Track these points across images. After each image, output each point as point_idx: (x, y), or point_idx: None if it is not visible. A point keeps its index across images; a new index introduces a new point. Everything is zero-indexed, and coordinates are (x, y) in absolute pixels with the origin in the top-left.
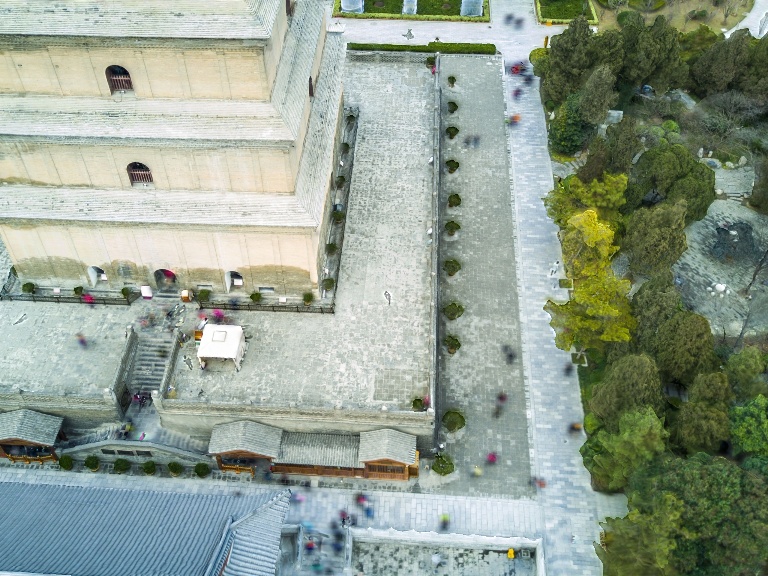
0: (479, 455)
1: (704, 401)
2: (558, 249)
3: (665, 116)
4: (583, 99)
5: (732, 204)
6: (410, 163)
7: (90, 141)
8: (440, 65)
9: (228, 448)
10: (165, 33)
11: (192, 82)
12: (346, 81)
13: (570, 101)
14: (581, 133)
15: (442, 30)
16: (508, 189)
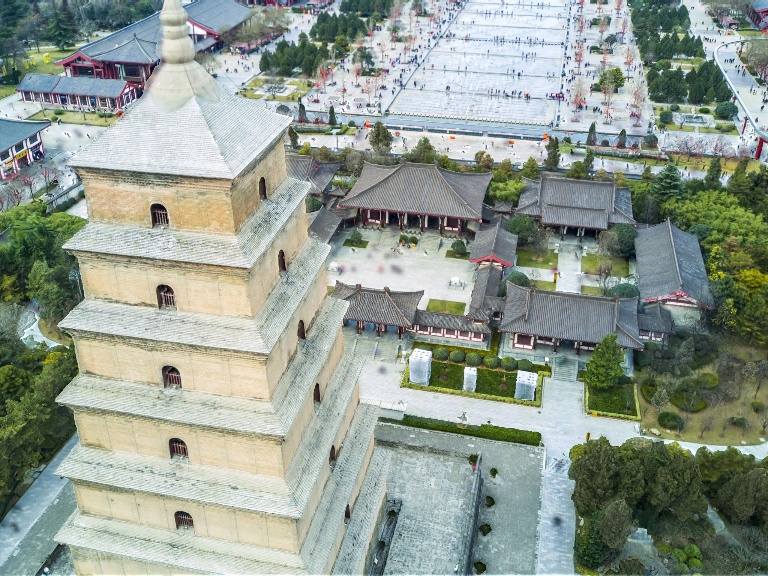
0: None
1: None
2: None
3: (689, 538)
4: (603, 523)
5: None
6: (437, 568)
7: (154, 562)
8: (487, 452)
9: None
10: (222, 501)
11: (240, 531)
12: (396, 469)
13: (593, 520)
14: (603, 551)
15: (496, 411)
16: None
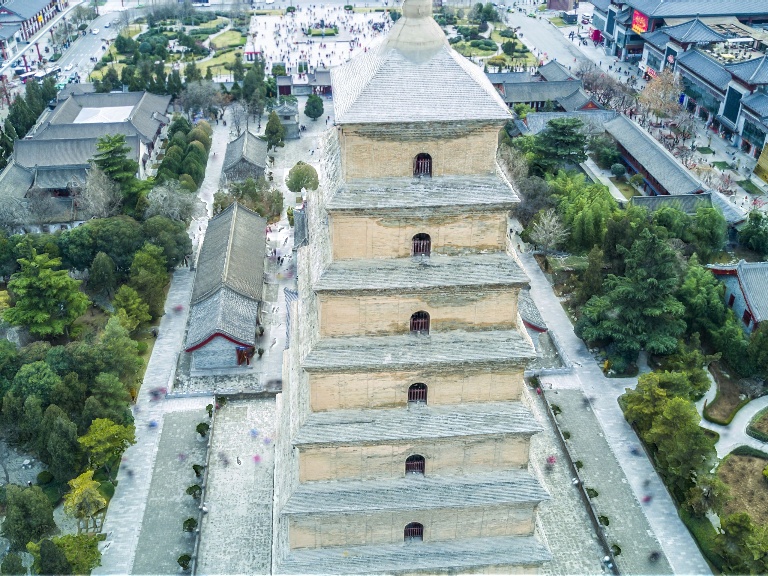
0: (191, 426)
1: (70, 389)
2: (96, 568)
3: None
4: None
5: None
6: None
7: None
8: None
9: None
10: None
11: None
12: None
13: None
14: None
15: None
16: None
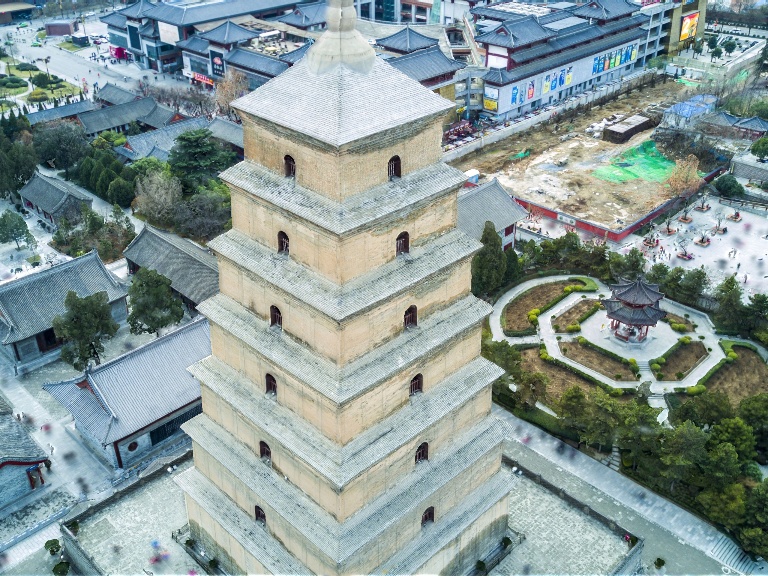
0: (39, 575)
1: None
2: None
3: None
4: None
5: None
6: None
7: None
8: None
9: (163, 458)
10: None
11: None
12: None
13: None
14: None
15: None
16: None
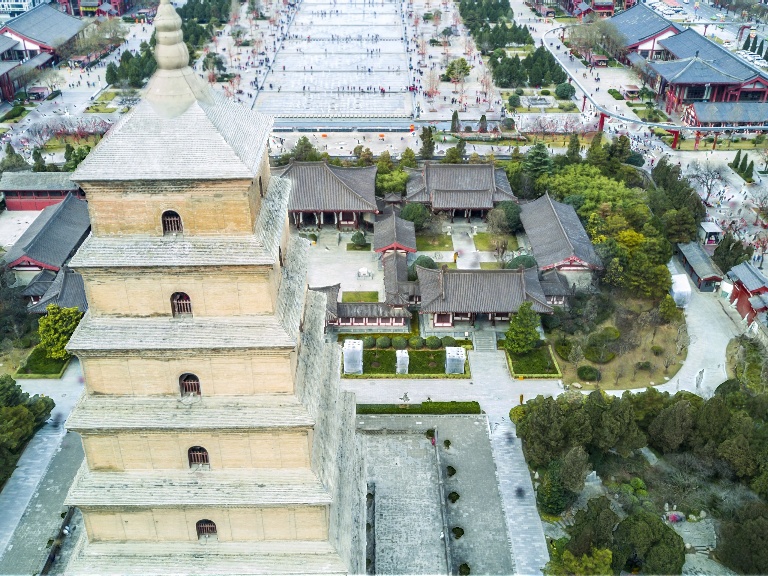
0: None
1: None
2: None
3: None
4: (563, 471)
5: (701, 558)
6: (424, 539)
7: None
8: None
9: None
10: (251, 501)
11: (266, 529)
12: None
13: (552, 470)
14: (564, 497)
15: (432, 388)
16: (508, 553)
